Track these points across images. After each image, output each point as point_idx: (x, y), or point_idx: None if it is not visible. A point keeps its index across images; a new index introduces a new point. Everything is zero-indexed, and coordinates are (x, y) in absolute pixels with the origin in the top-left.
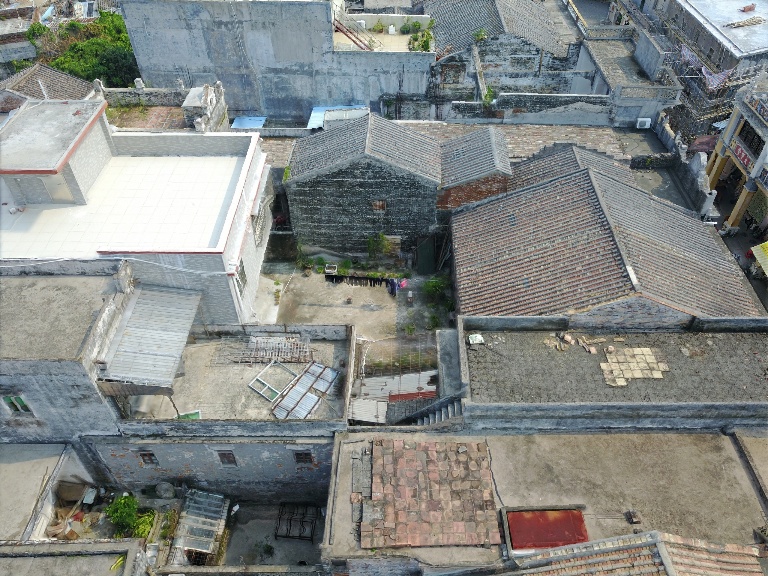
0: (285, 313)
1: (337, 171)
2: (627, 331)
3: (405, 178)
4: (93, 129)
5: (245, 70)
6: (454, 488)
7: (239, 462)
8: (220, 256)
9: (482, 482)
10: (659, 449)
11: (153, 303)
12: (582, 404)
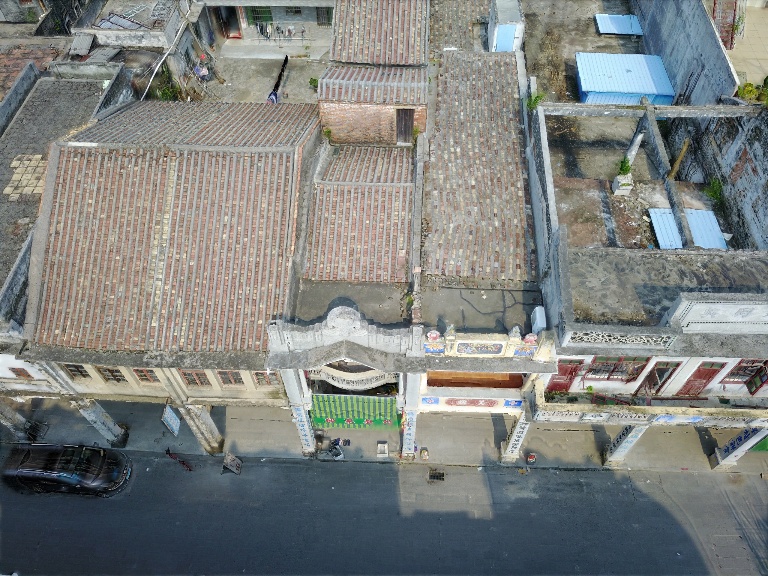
0: (280, 63)
1: None
2: None
3: None
4: None
5: None
6: None
7: None
8: None
9: None
10: None
11: None
12: None
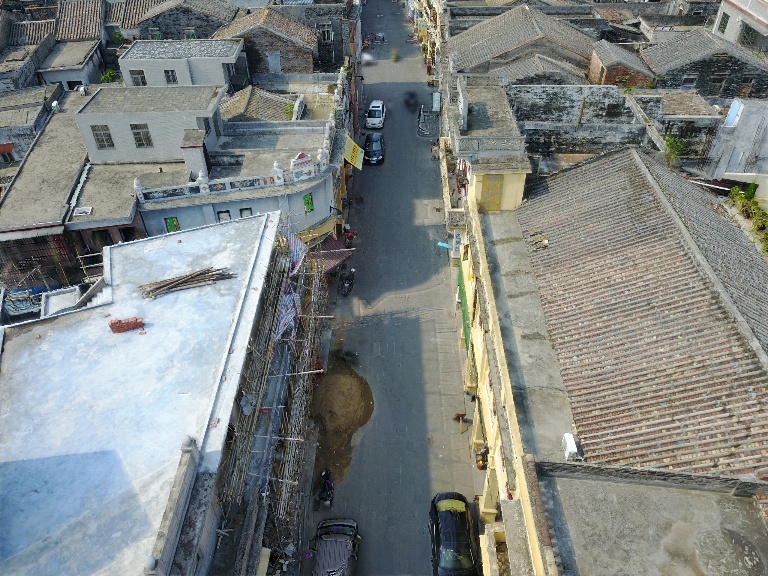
0: None
1: None
2: None
3: None
4: None
5: None
6: None
7: None
8: None
9: None
10: None
11: None
12: None
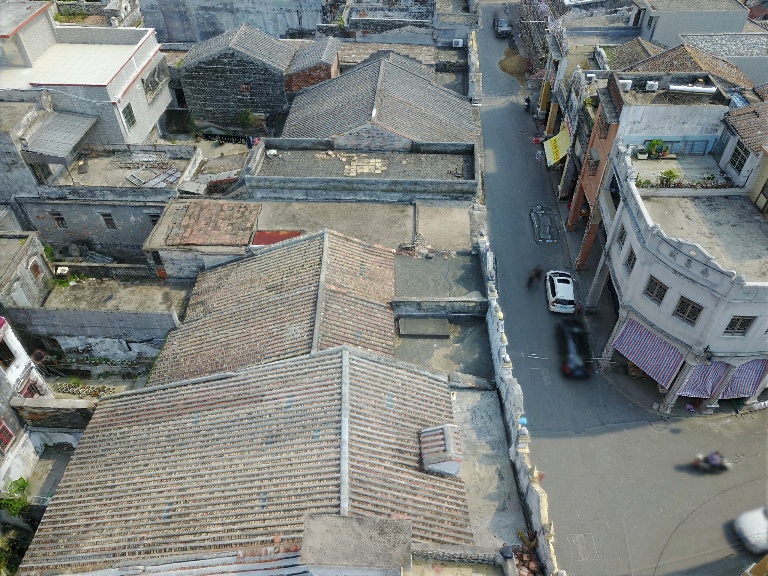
0: None
1: (212, 59)
2: (372, 152)
3: (259, 66)
4: (41, 20)
5: (183, 8)
6: (231, 222)
7: (117, 226)
8: (106, 89)
9: (249, 220)
10: (366, 210)
11: (65, 119)
12: (316, 178)
